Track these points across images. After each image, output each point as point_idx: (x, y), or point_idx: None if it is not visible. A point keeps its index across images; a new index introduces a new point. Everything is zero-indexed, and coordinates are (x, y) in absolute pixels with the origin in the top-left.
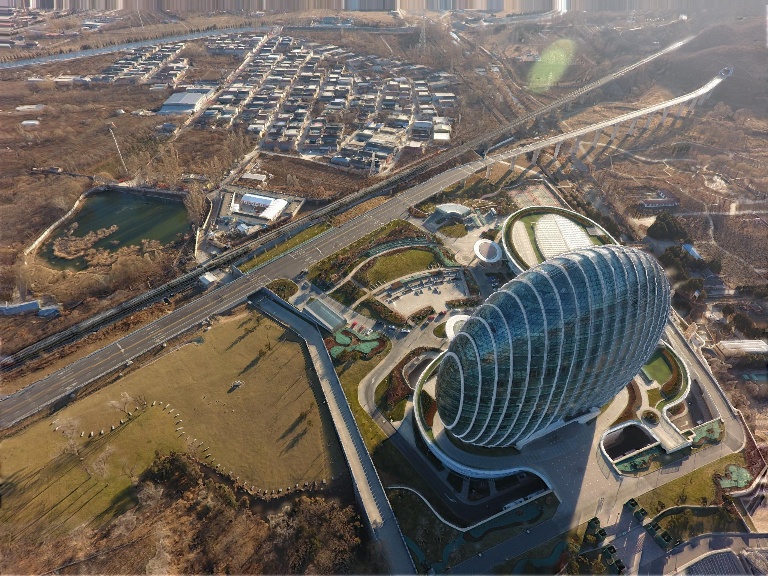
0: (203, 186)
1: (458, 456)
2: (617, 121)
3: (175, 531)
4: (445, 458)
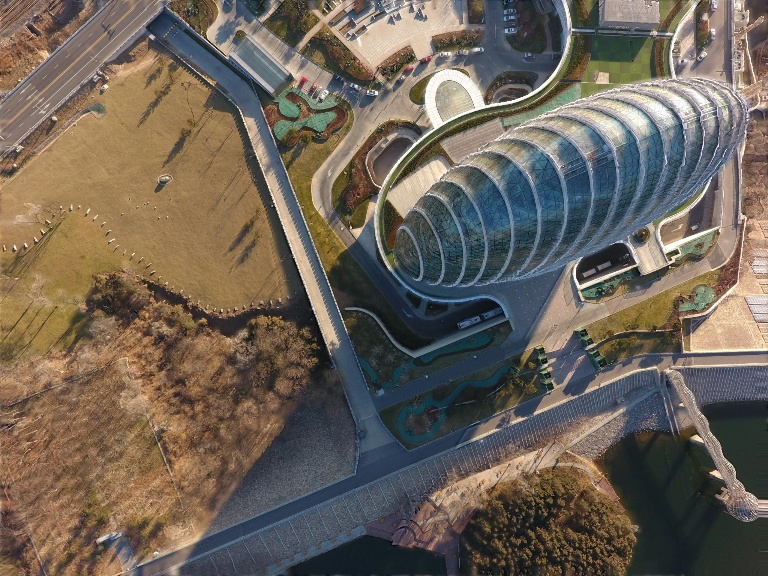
0: None
1: (418, 283)
2: None
3: (140, 356)
4: None
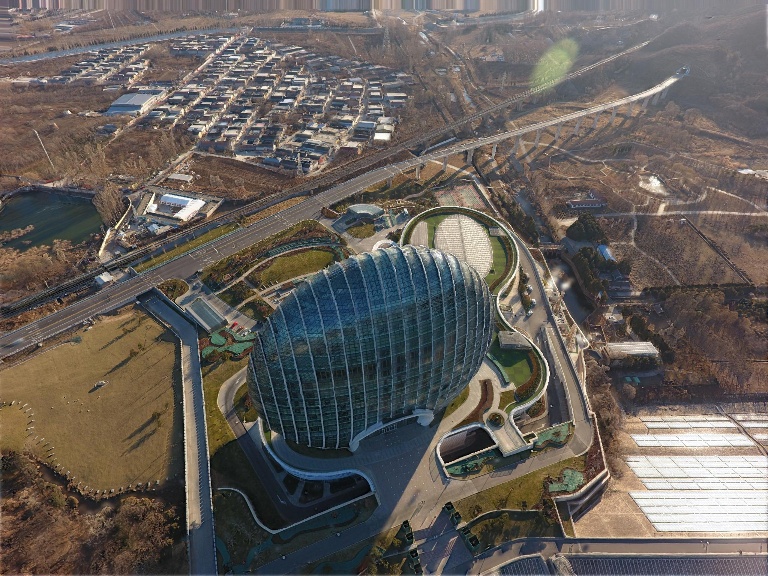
0: (128, 186)
1: (289, 458)
2: (558, 121)
3: None
4: (276, 459)
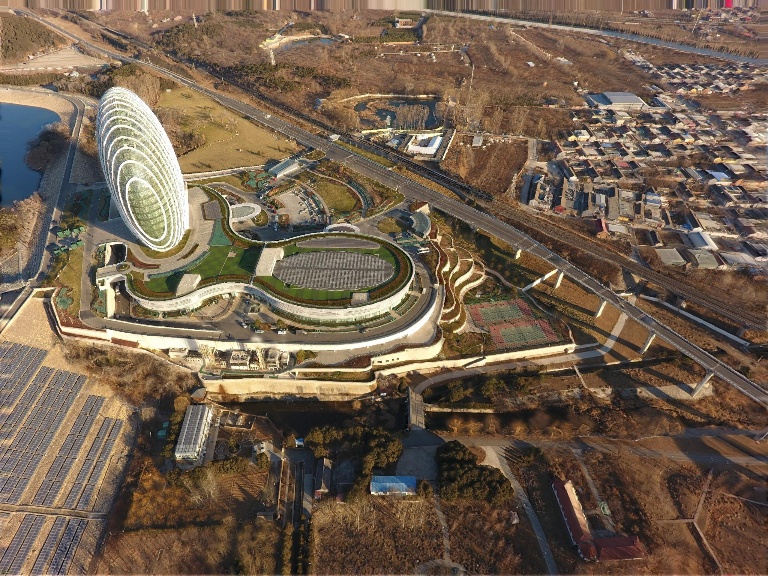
0: None
1: None
2: None
3: None
4: None
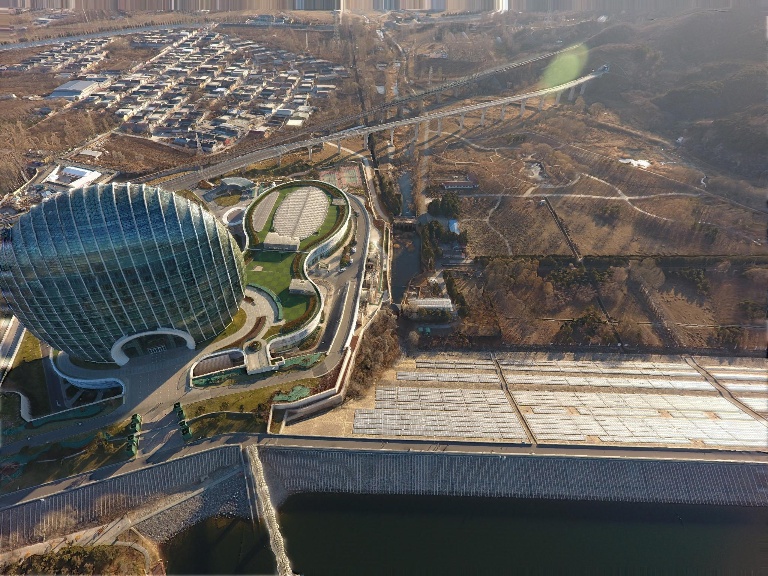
0: (41, 160)
1: (66, 368)
2: (458, 111)
3: None
4: None
